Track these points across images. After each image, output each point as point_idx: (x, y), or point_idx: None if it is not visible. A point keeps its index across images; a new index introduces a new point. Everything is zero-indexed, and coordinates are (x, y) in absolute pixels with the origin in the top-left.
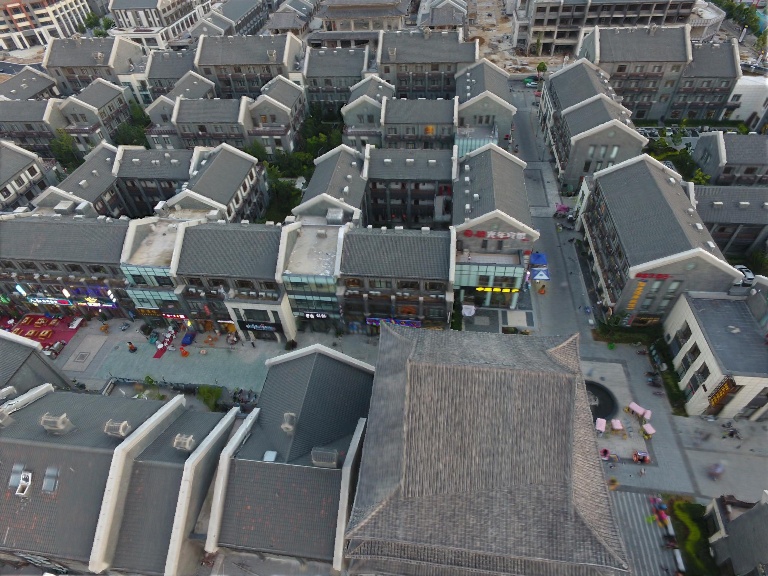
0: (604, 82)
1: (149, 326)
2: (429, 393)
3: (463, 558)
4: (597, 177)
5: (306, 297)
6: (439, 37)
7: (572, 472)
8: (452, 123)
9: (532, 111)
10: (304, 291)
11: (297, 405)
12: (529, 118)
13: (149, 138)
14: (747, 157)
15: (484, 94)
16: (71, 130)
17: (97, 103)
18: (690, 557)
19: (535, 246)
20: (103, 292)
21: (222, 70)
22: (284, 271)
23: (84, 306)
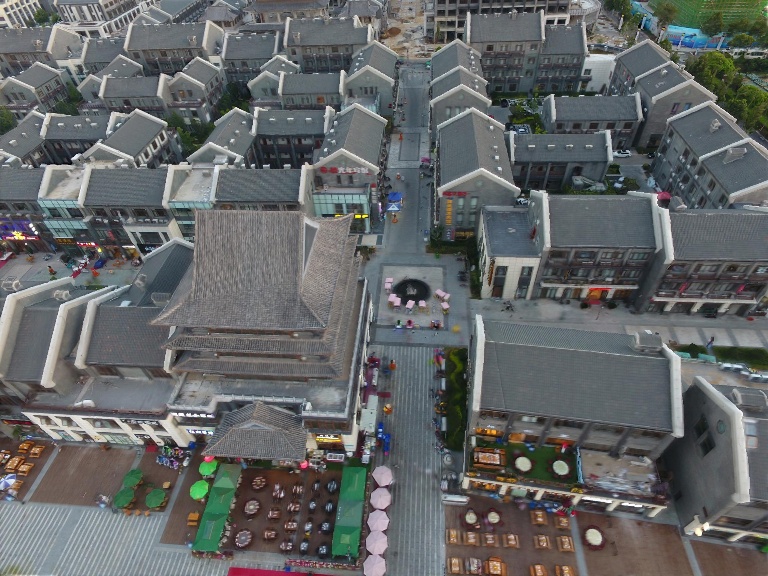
0: (471, 58)
1: (68, 256)
2: (210, 230)
3: (241, 345)
4: (440, 129)
5: (191, 222)
6: (338, 23)
7: (300, 275)
8: (338, 93)
9: (426, 88)
10: (188, 216)
11: (154, 275)
12: (422, 94)
13: (81, 112)
14: (573, 115)
15: (365, 68)
16: (11, 107)
17: (35, 83)
18: (452, 382)
19: (399, 189)
20: (27, 227)
21: (150, 54)
22: (171, 200)
23: (13, 241)
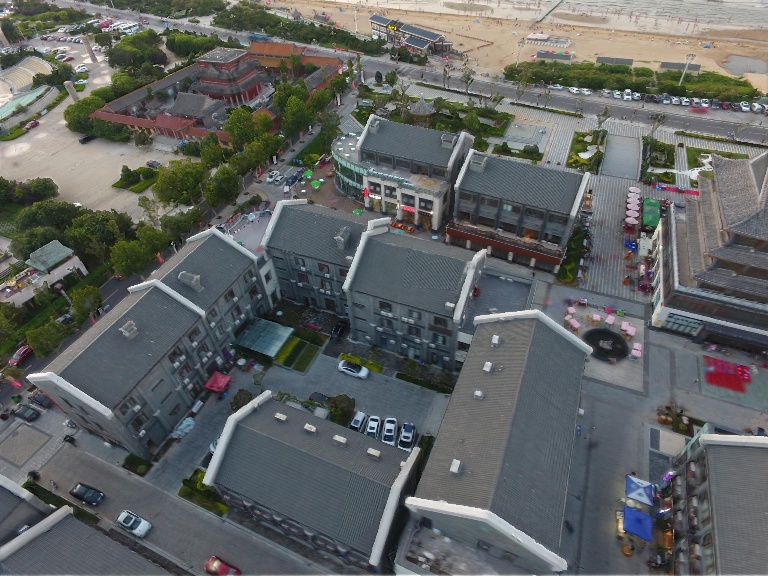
0: None
1: None
2: None
3: None
4: None
5: None
6: None
7: None
8: None
9: None
10: None
11: None
12: None
13: None
14: None
15: None
16: None
17: None
18: None
19: None
20: None
21: None
22: None
23: None
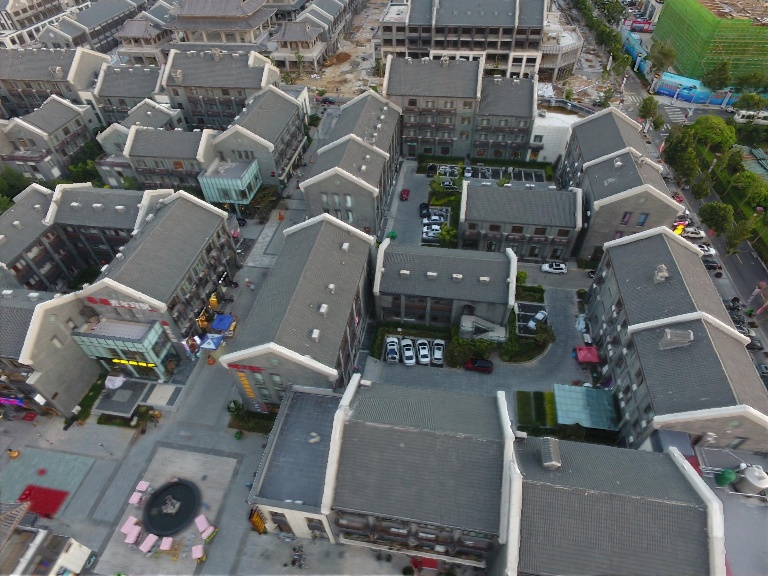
0: (380, 118)
1: None
2: None
3: None
4: (286, 235)
5: None
6: (230, 59)
7: None
8: (197, 159)
9: None
10: None
11: None
12: None
13: None
14: (489, 213)
15: (233, 128)
16: None
17: None
18: None
19: (242, 304)
20: None
21: (13, 85)
22: None
23: None
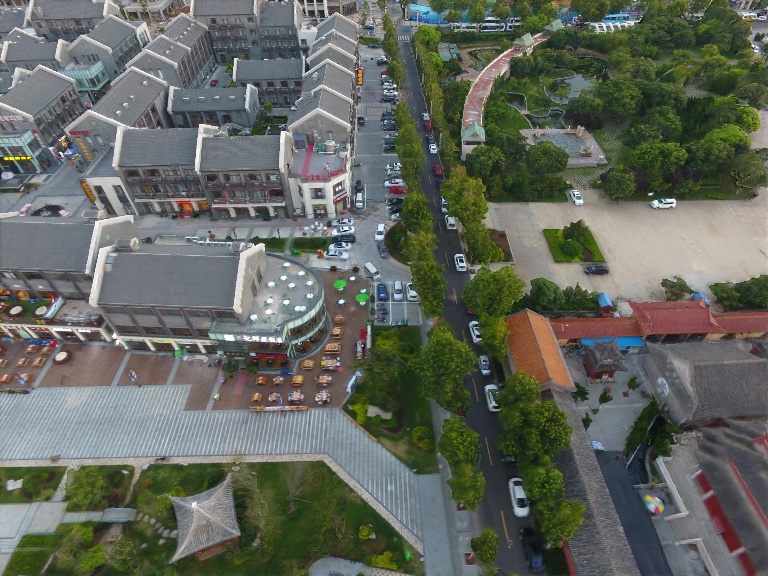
0: (187, 29)
1: None
2: None
3: None
4: (112, 85)
5: None
6: None
7: None
8: None
9: None
10: None
11: None
12: None
13: None
14: (251, 75)
15: (80, 37)
16: None
17: None
18: None
19: None
20: None
21: None
22: None
23: None
